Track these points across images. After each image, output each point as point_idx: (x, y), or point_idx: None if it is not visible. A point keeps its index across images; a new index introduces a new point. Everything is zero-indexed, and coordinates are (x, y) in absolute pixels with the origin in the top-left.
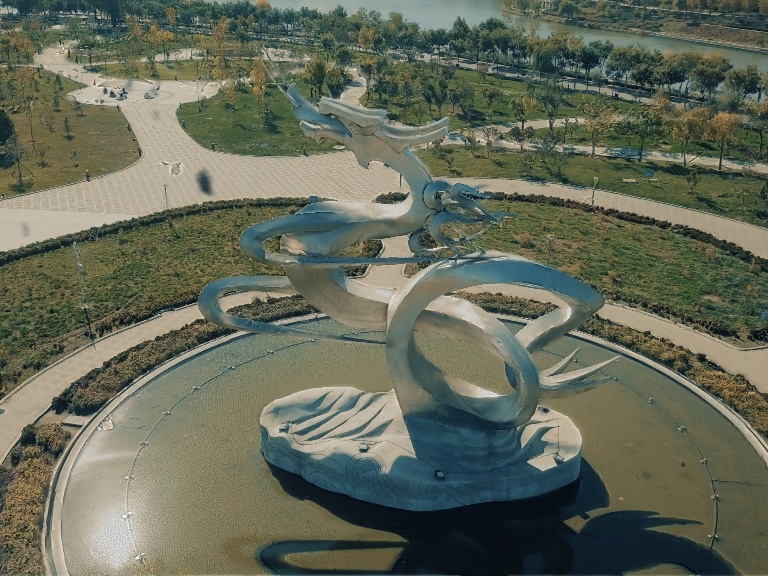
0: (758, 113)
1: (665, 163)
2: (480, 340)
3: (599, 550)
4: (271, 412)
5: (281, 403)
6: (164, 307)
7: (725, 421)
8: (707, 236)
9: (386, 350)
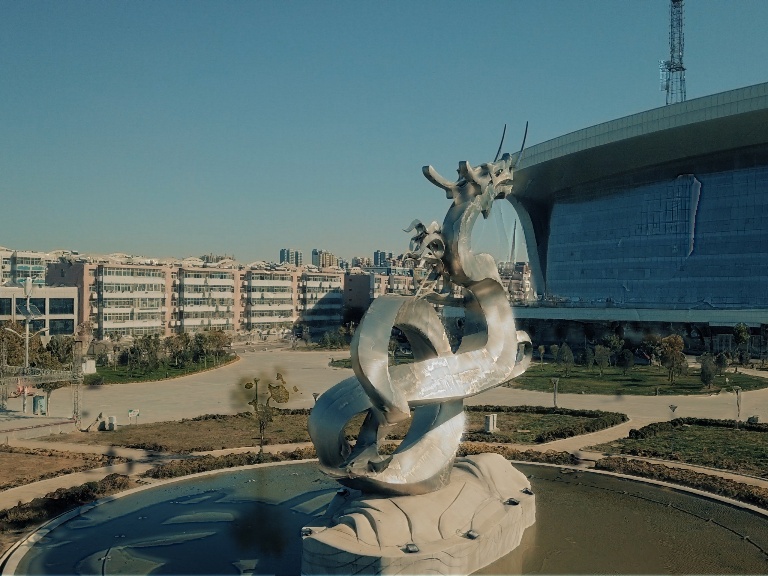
0: None
1: None
2: None
3: None
4: None
5: None
6: None
7: None
8: None
9: None
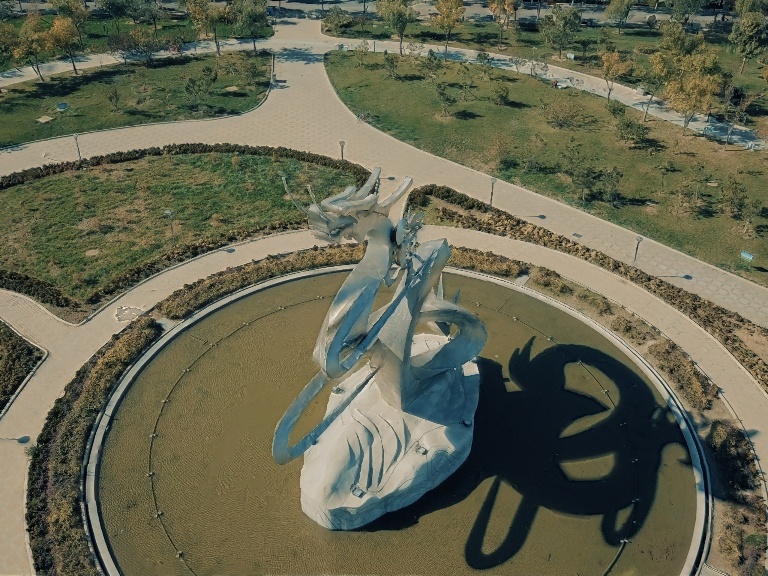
0: (73, 9)
1: (26, 86)
2: (423, 319)
3: (535, 390)
4: (332, 494)
5: (332, 480)
6: None
7: (442, 274)
8: (202, 146)
9: (401, 372)
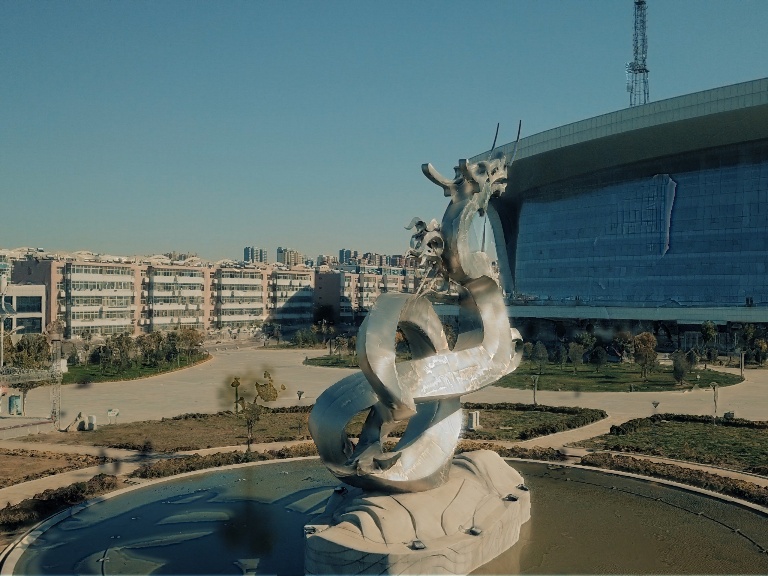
0: None
1: None
2: None
3: None
4: None
5: None
6: None
7: None
8: None
9: None
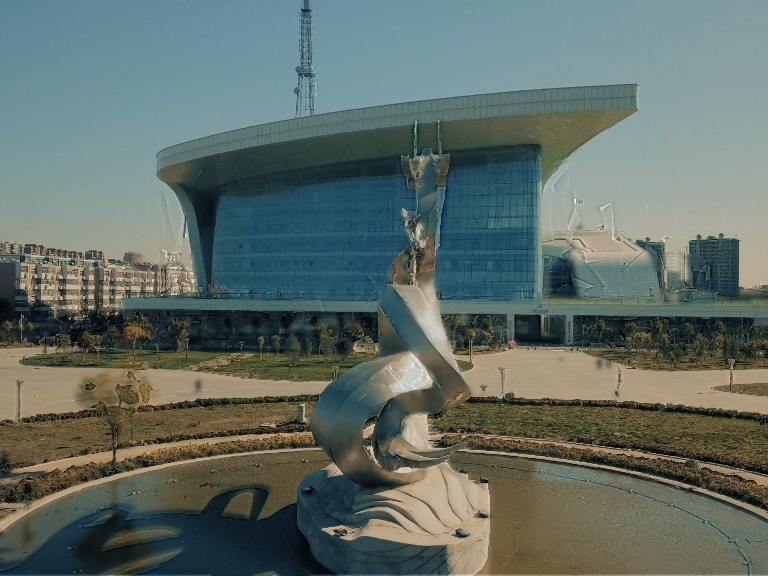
0: None
1: None
2: None
3: None
4: None
5: None
6: (644, 448)
7: None
8: None
9: None
